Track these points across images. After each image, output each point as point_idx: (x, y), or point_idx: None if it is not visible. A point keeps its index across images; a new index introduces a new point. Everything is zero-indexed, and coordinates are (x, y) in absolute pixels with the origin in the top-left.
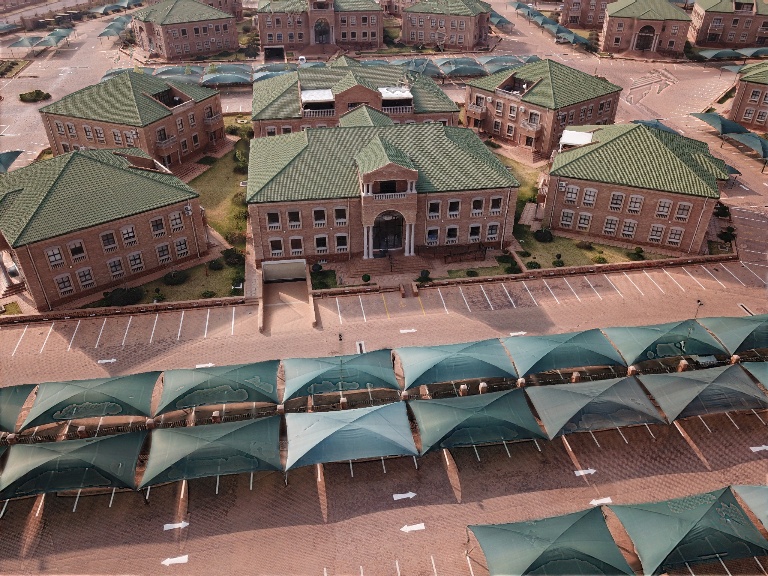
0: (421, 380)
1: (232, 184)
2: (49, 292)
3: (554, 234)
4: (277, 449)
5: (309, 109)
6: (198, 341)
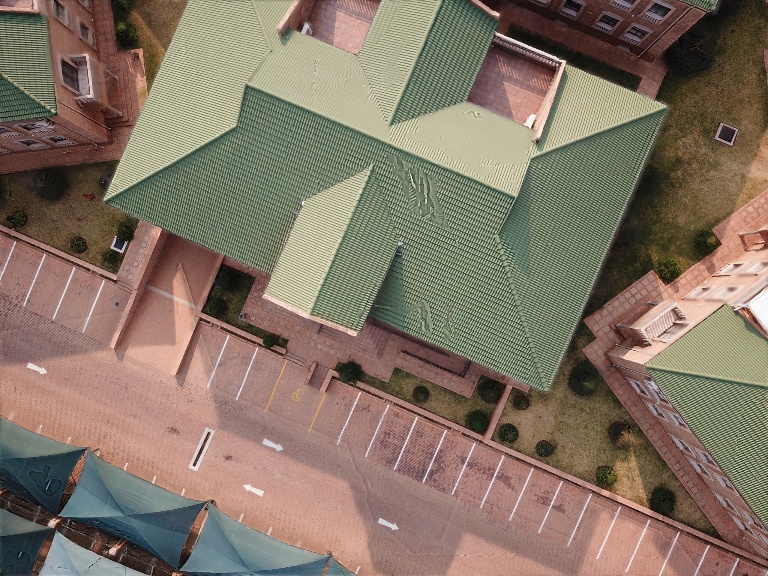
0: (199, 574)
1: None
2: None
3: (608, 380)
4: (29, 569)
5: None
6: (43, 322)
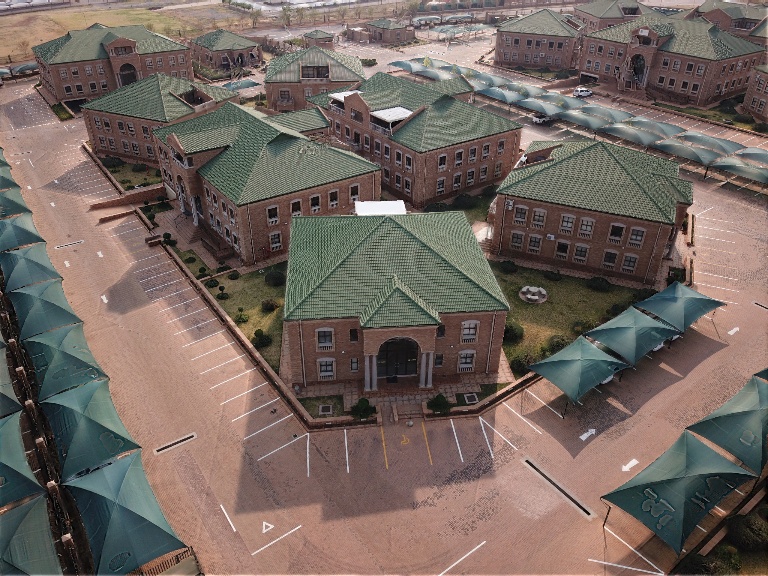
0: None
1: None
2: (97, 142)
3: None
4: None
5: (336, 104)
6: (78, 196)
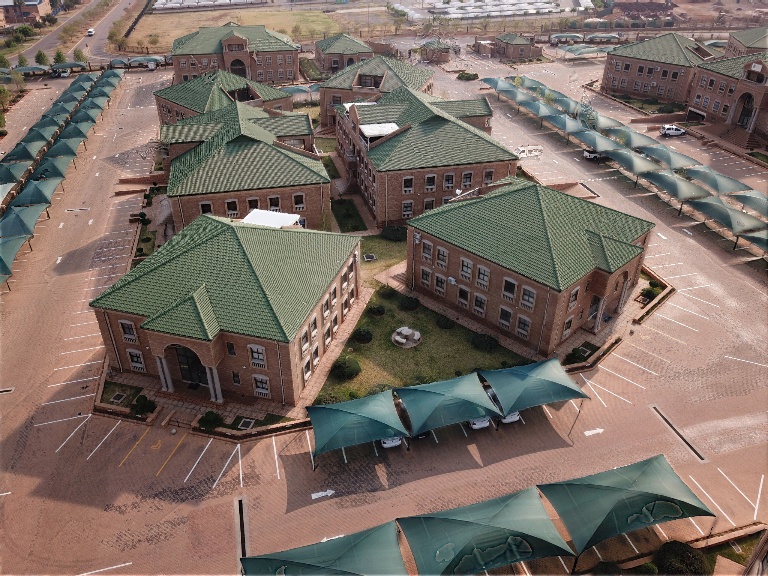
0: None
1: (318, 149)
2: None
3: None
4: None
5: None
6: (121, 170)
